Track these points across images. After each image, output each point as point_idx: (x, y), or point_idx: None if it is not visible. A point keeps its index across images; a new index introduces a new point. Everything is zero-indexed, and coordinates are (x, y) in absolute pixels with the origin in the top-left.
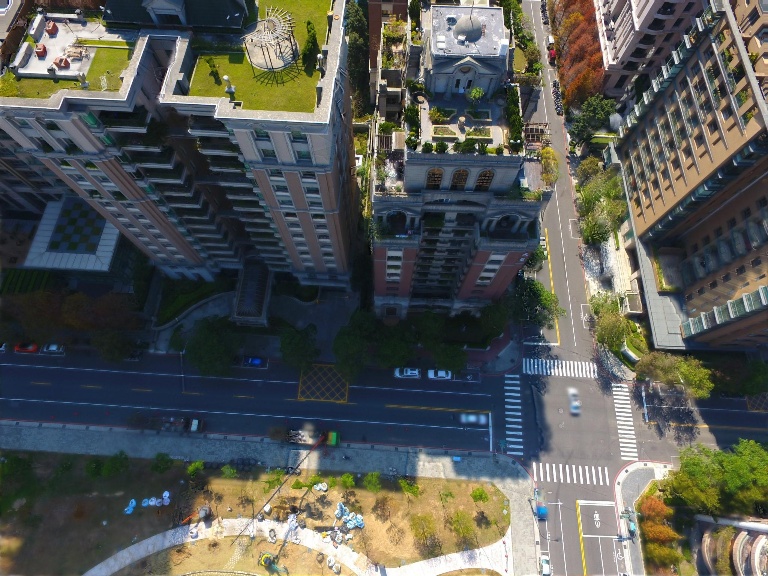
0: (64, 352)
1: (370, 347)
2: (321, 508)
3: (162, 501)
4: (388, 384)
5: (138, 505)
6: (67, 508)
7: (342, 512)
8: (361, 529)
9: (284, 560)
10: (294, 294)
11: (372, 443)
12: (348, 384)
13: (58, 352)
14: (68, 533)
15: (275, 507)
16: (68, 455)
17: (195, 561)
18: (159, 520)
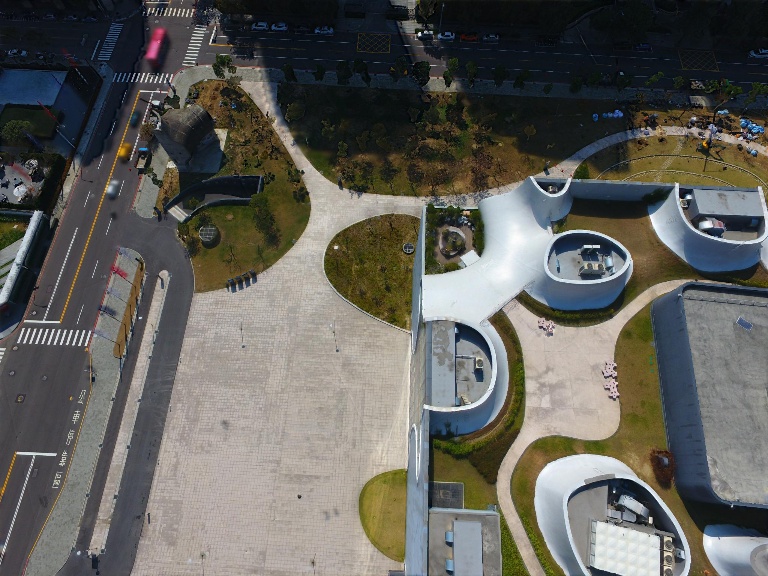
0: (497, 41)
1: (725, 40)
2: (729, 122)
3: (618, 113)
4: (745, 62)
5: (599, 117)
6: (546, 121)
7: (747, 123)
8: (762, 134)
9: (714, 149)
10: (664, 3)
11: (747, 93)
12: (716, 61)
13: (494, 40)
14: (557, 130)
15: (695, 122)
16: (528, 97)
17: (651, 148)
18: (619, 125)
